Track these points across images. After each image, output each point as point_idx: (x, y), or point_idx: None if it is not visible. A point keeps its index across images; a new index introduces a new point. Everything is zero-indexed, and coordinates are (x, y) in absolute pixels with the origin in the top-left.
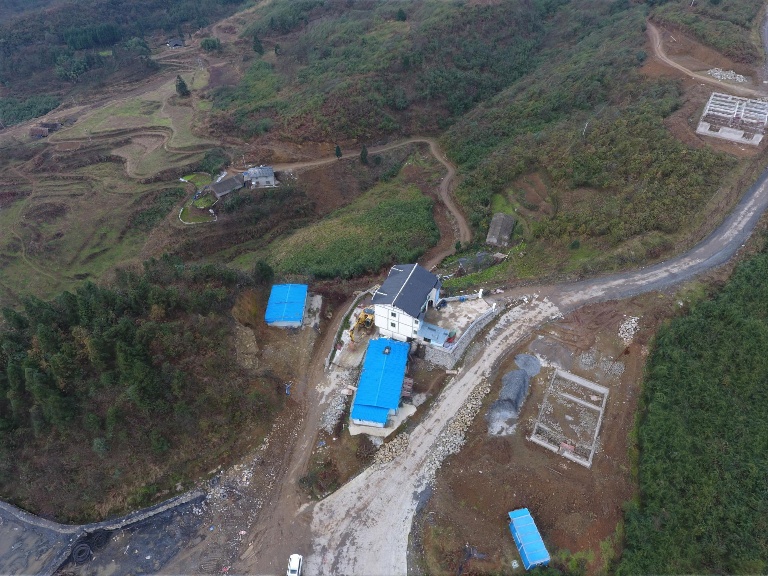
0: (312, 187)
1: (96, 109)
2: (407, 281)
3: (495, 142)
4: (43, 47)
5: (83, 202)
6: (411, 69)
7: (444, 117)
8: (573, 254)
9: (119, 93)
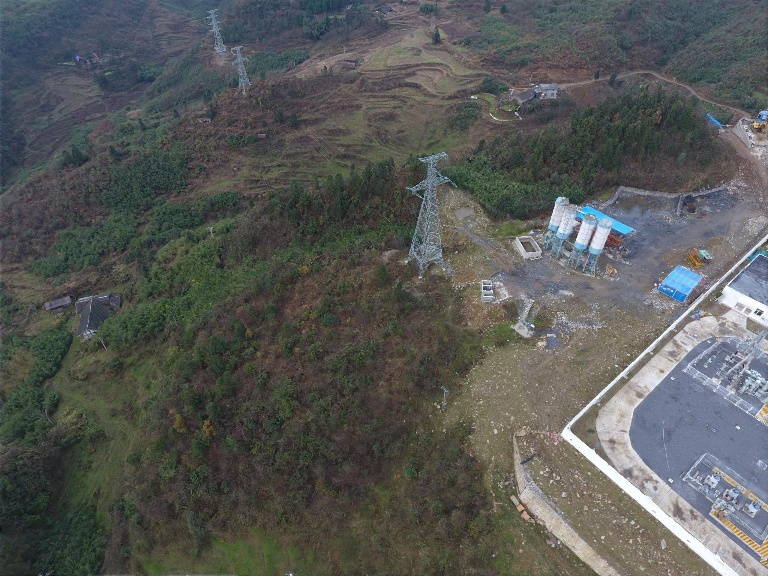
0: (580, 100)
1: (368, 53)
2: None
3: (725, 65)
4: (290, 11)
5: (408, 111)
6: (633, 18)
7: (659, 55)
8: None
9: (361, 46)
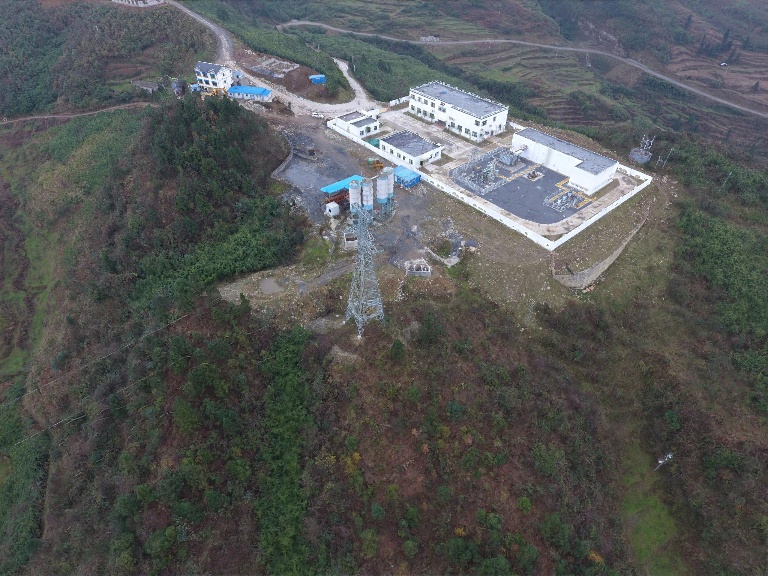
0: None
1: None
2: None
3: (34, 83)
4: None
5: None
6: None
7: None
8: (195, 59)
9: None
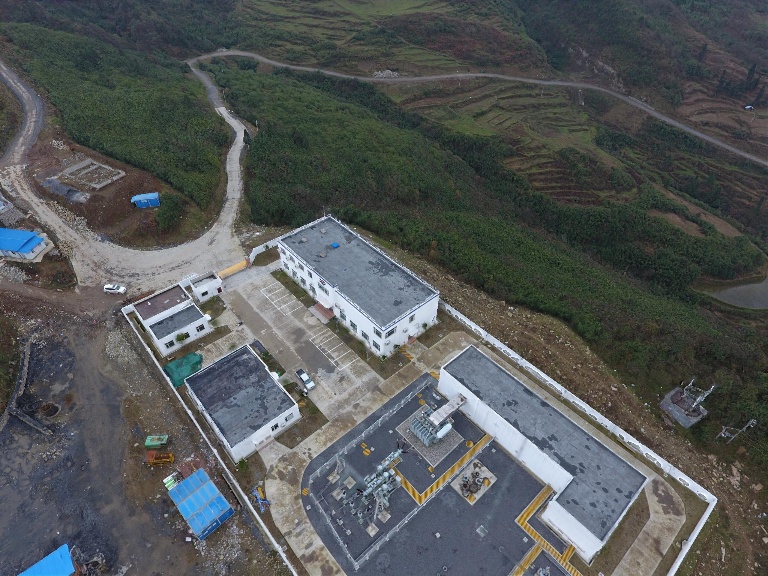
0: None
1: None
2: None
3: None
4: None
5: None
6: None
7: None
8: None
9: None
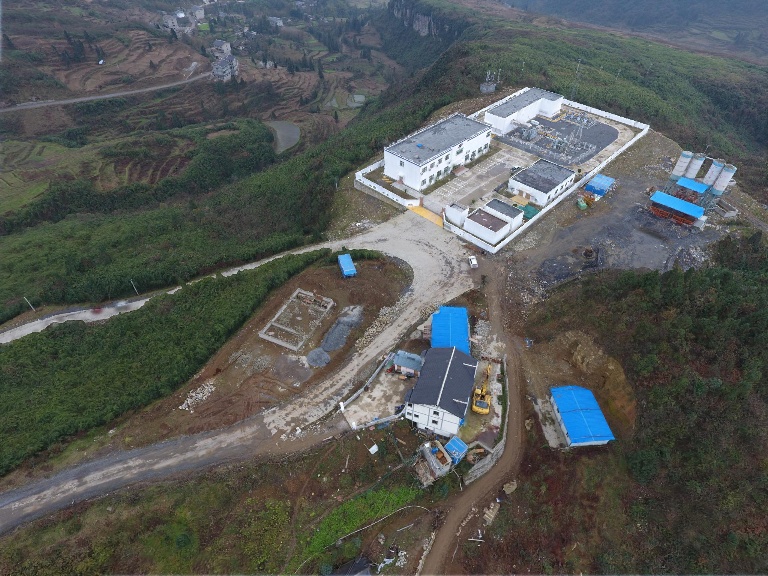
0: None
1: None
2: (445, 377)
3: None
4: None
5: None
6: None
7: None
8: None
9: None
